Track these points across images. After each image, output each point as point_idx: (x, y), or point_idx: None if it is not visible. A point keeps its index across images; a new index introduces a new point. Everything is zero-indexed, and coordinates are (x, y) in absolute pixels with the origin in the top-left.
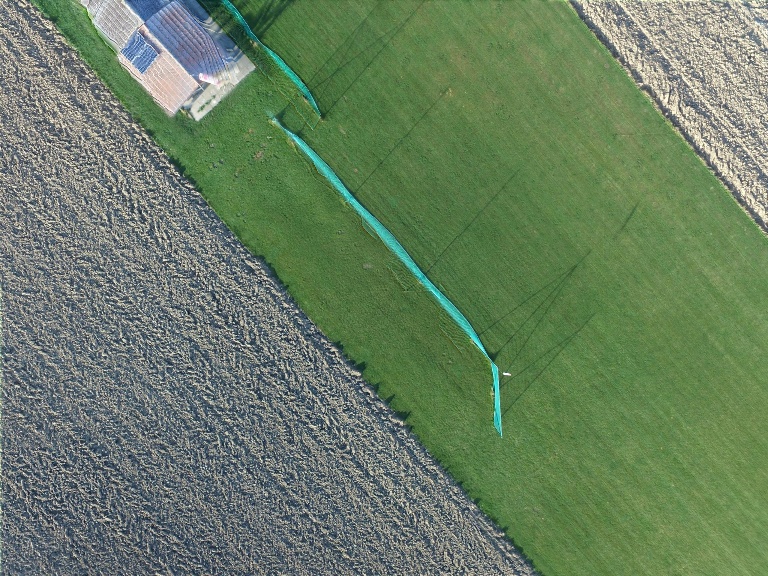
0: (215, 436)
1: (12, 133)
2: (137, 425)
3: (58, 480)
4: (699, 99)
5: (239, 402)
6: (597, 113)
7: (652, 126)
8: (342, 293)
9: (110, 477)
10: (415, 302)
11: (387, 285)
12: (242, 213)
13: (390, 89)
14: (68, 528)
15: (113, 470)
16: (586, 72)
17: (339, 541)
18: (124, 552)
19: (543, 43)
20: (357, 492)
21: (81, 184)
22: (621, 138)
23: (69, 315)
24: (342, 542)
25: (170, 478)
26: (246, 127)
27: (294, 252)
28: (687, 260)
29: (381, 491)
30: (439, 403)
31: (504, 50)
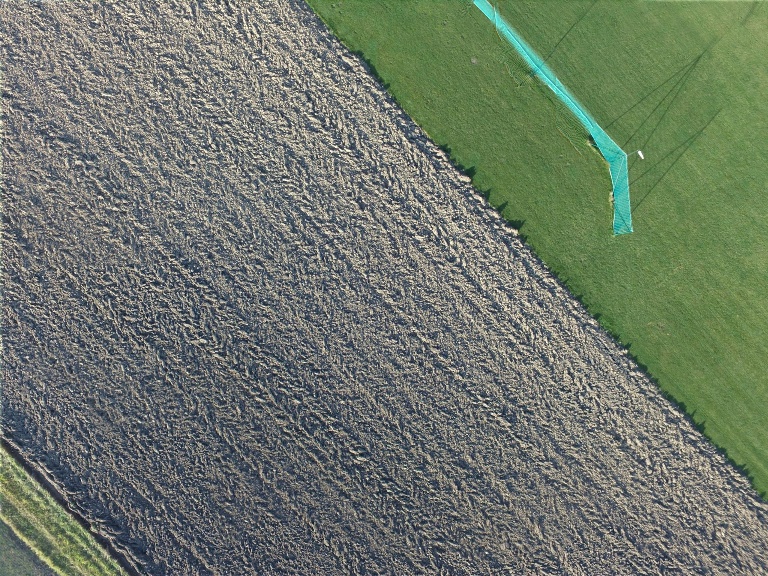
0: (314, 250)
1: None
2: (230, 239)
3: (148, 299)
4: None
5: (339, 212)
6: None
7: None
8: (449, 90)
9: (203, 296)
10: (529, 98)
11: (498, 80)
12: (337, 3)
13: None
14: (160, 350)
15: (206, 287)
16: None
17: (450, 361)
18: (221, 375)
19: None
20: (469, 308)
21: None
22: None
23: (153, 119)
24: (454, 362)
25: (267, 296)
26: None
27: (395, 46)
28: None
29: (495, 307)
30: (556, 210)
31: None
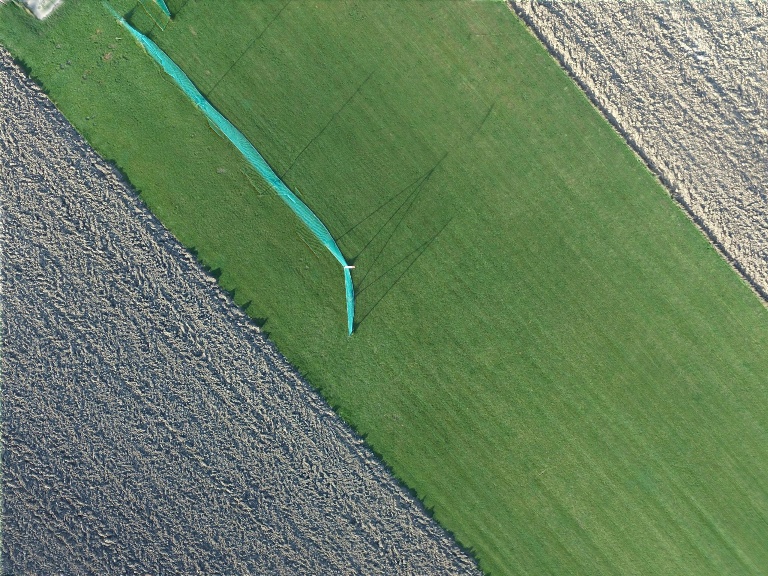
0: (67, 344)
1: None
2: None
3: None
4: None
5: (91, 309)
6: (451, 13)
7: (506, 26)
8: (196, 198)
9: None
10: (270, 206)
11: (242, 189)
12: (91, 116)
13: None
14: None
15: None
16: None
17: (196, 449)
18: None
19: None
20: (214, 399)
21: None
22: (475, 38)
23: None
24: (199, 450)
25: (21, 387)
26: (93, 27)
27: (146, 156)
28: (543, 162)
29: (238, 398)
30: (296, 309)
31: None
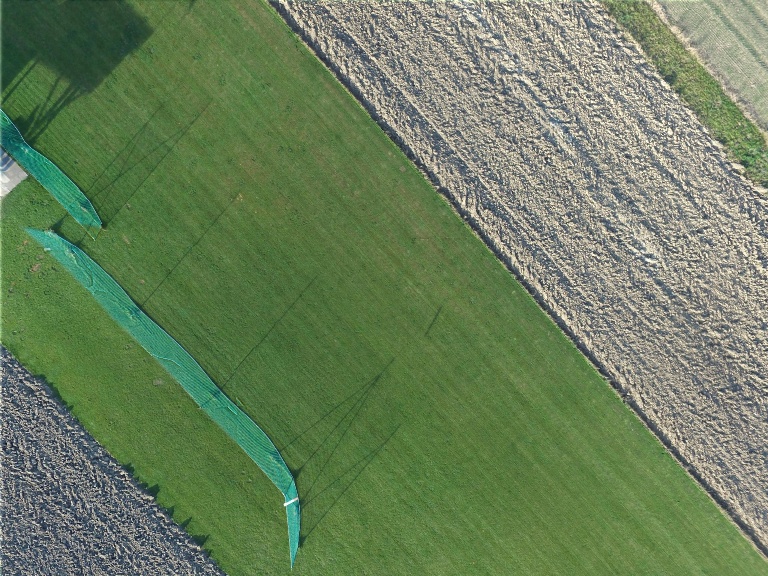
0: None
1: None
2: None
3: None
4: (497, 201)
5: (20, 534)
6: (394, 217)
7: (451, 230)
8: (131, 412)
9: None
10: (210, 419)
11: (180, 402)
12: (19, 330)
13: (177, 195)
14: None
15: None
16: (379, 176)
17: None
18: None
19: (335, 146)
20: None
21: None
22: (420, 242)
23: None
24: None
25: None
26: (20, 239)
27: (77, 370)
28: (492, 366)
29: None
30: (239, 524)
31: (295, 154)
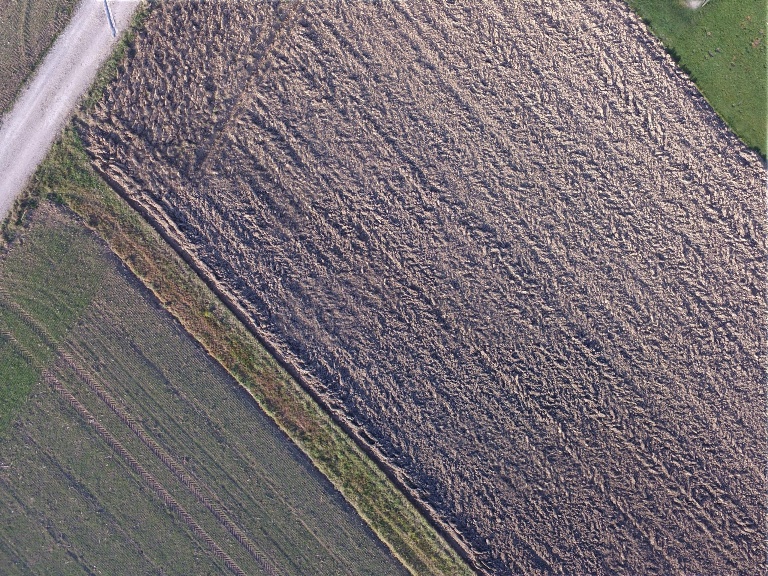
0: (708, 332)
1: (512, 26)
2: (629, 321)
3: (551, 375)
4: None
5: (733, 298)
6: None
7: None
8: None
9: (601, 373)
10: None
11: None
12: (738, 103)
13: None
14: (561, 423)
15: (606, 366)
16: None
17: None
18: (617, 448)
19: None
20: None
21: (577, 77)
22: None
23: (563, 210)
24: None
25: (662, 374)
26: (745, 13)
27: None
28: None
29: None
30: None
31: None
